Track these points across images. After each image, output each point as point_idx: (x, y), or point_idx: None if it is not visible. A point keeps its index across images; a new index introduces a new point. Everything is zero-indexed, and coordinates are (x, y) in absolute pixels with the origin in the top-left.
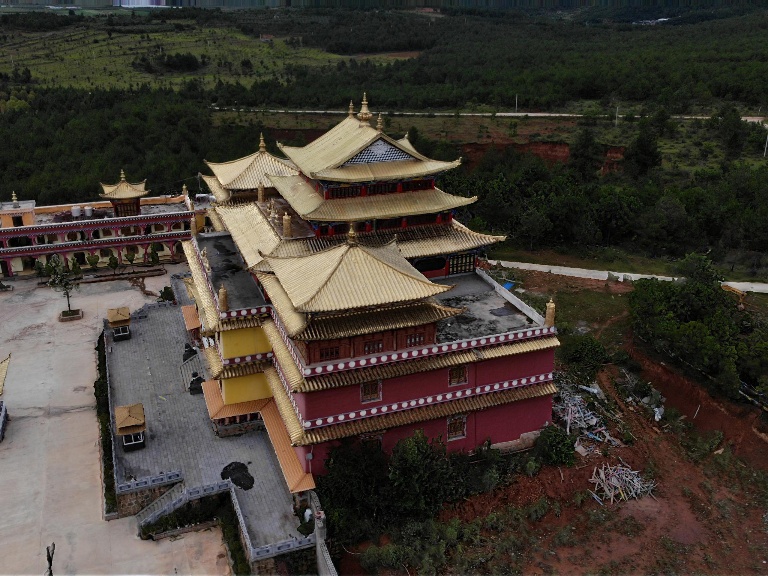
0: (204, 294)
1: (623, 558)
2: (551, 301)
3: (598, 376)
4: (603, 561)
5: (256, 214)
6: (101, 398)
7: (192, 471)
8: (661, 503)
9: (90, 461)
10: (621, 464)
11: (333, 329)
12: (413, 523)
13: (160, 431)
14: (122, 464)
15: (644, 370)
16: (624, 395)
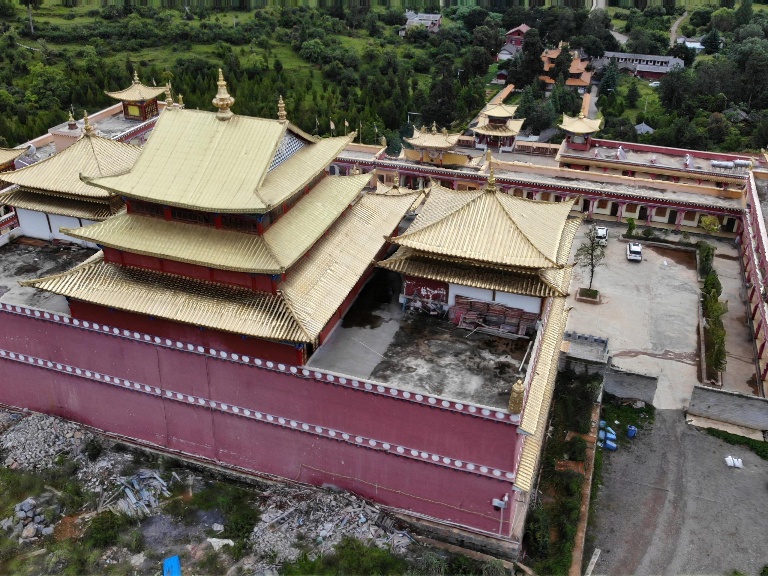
0: None
1: None
2: None
3: None
4: None
5: None
6: None
7: None
8: None
9: None
10: None
11: None
12: None
13: None
14: None
15: None
16: None
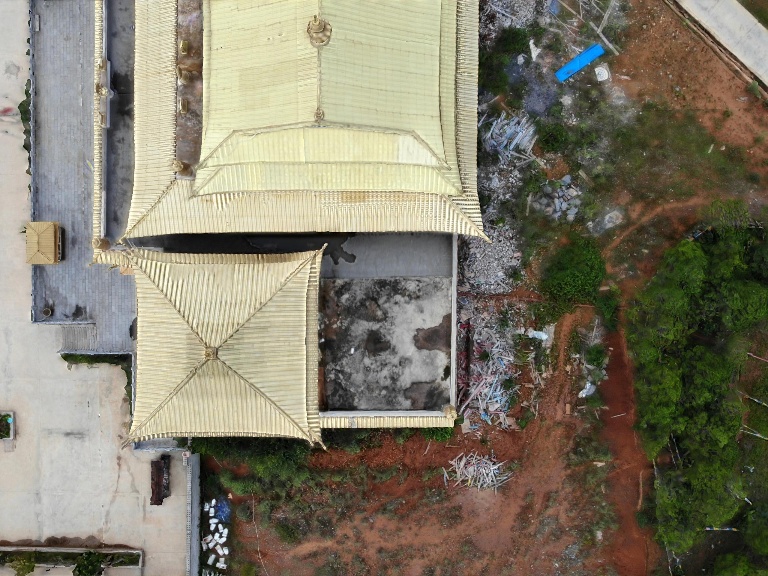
0: (99, 154)
1: (422, 545)
2: (452, 418)
3: (563, 317)
4: (404, 542)
5: (171, 30)
6: (26, 140)
7: (105, 314)
8: (497, 500)
9: (23, 225)
10: (489, 457)
11: None
12: None
13: (82, 233)
14: (43, 279)
15: (618, 332)
16: (573, 350)
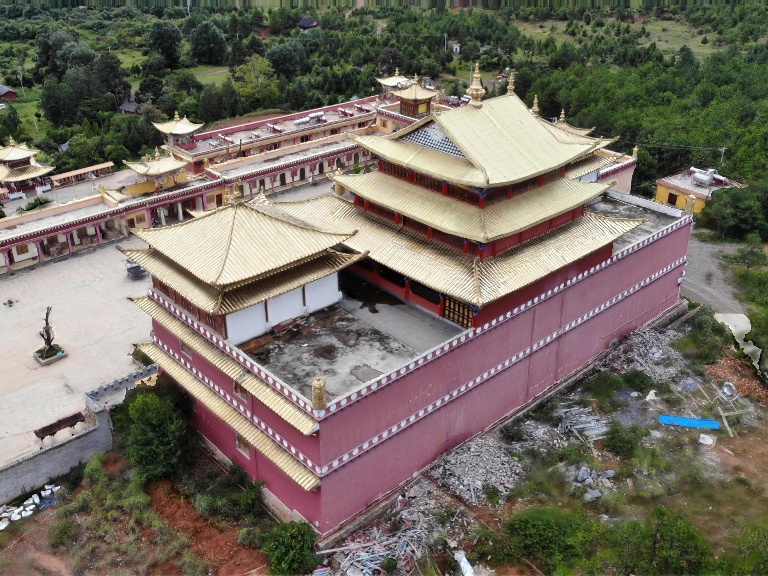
0: None
1: None
2: None
3: (506, 569)
4: None
5: None
6: None
7: None
8: None
9: None
10: None
11: (155, 265)
12: (135, 471)
13: None
14: None
15: None
16: None
